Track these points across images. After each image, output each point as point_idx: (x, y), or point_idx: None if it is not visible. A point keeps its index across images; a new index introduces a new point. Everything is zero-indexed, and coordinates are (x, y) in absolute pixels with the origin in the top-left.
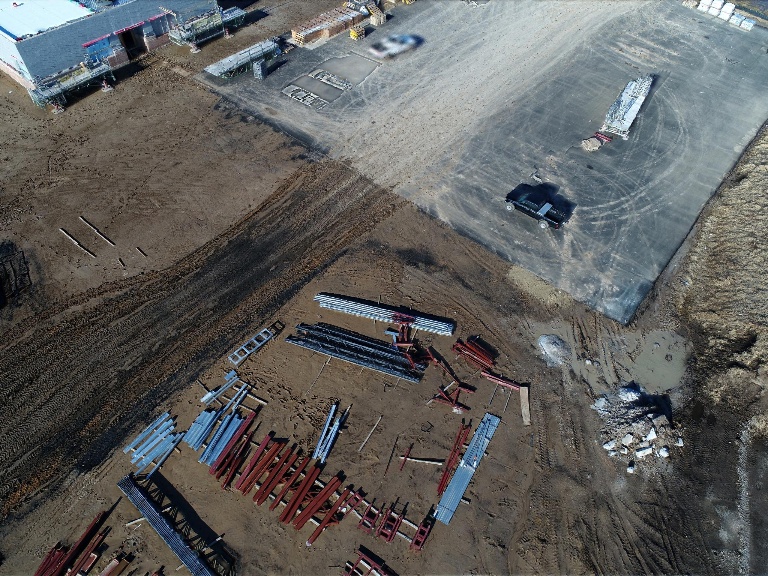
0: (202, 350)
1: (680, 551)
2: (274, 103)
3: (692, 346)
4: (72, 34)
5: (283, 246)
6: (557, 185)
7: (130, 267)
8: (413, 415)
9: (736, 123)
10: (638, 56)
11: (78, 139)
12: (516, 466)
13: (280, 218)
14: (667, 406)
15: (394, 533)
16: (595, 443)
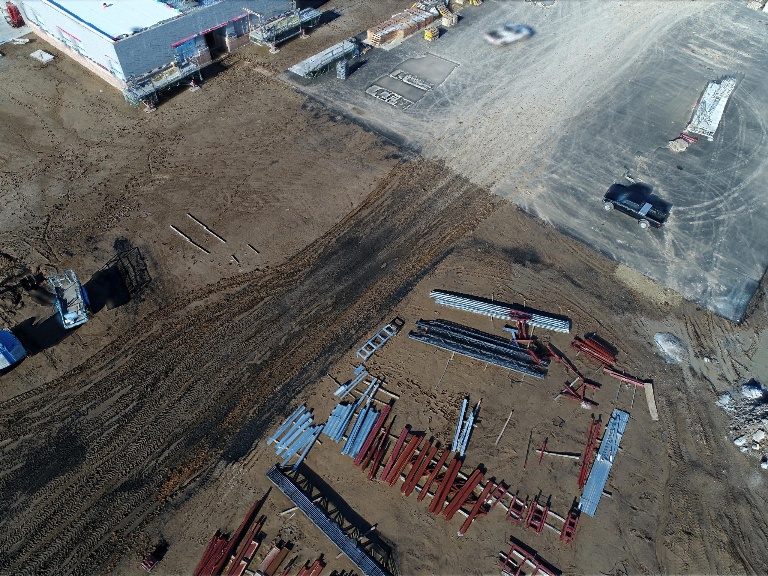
0: (328, 345)
1: None
2: (360, 103)
3: None
4: (164, 34)
5: (390, 244)
6: (650, 185)
7: (244, 263)
8: (543, 410)
9: None
10: (711, 58)
11: (173, 138)
12: (651, 460)
13: (383, 216)
14: None
15: (542, 524)
16: (725, 439)
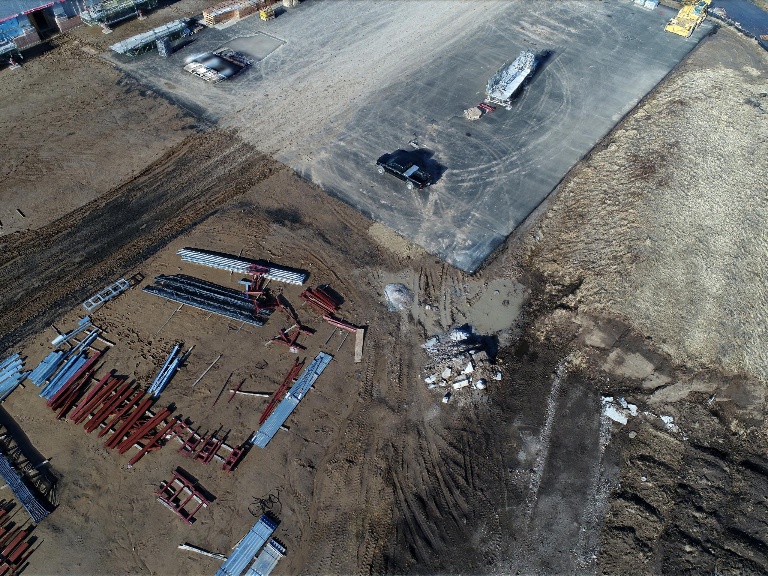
0: (61, 299)
1: (478, 470)
2: (174, 78)
3: (530, 293)
4: None
5: (157, 207)
6: (432, 151)
7: (7, 226)
8: (251, 354)
9: (619, 94)
10: (538, 34)
11: None
12: (339, 398)
13: (160, 182)
14: (494, 345)
15: (211, 456)
16: (418, 377)
